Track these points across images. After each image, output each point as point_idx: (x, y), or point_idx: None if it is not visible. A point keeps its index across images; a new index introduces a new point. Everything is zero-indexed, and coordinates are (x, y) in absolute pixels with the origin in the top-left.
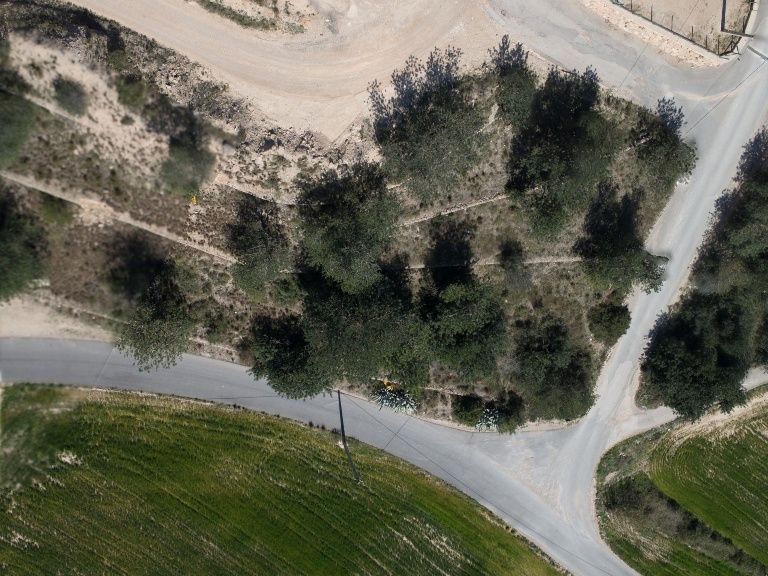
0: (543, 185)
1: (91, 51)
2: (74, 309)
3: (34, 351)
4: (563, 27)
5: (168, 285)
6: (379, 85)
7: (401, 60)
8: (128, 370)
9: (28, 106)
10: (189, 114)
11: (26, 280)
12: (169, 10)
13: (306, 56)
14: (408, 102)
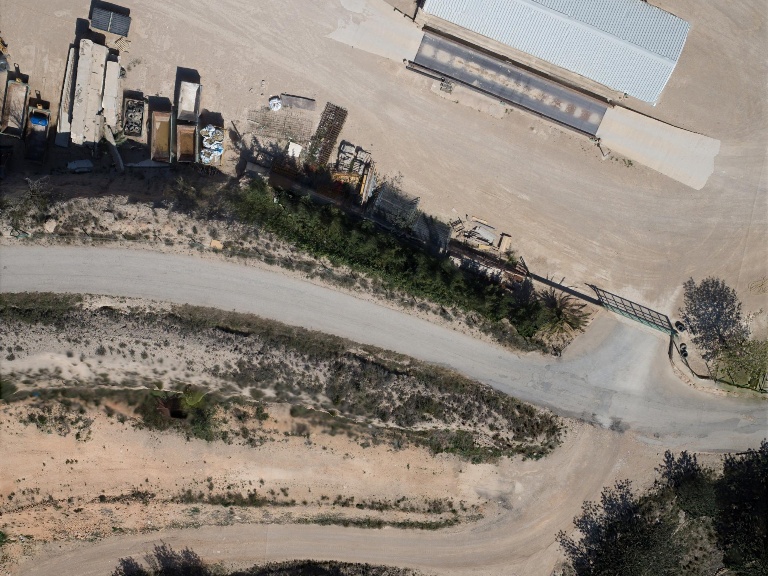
0: (758, 561)
1: None
2: None
3: None
4: (721, 421)
5: None
6: (565, 533)
7: (577, 508)
8: None
9: None
10: None
11: None
12: (370, 538)
13: (493, 533)
14: (597, 538)
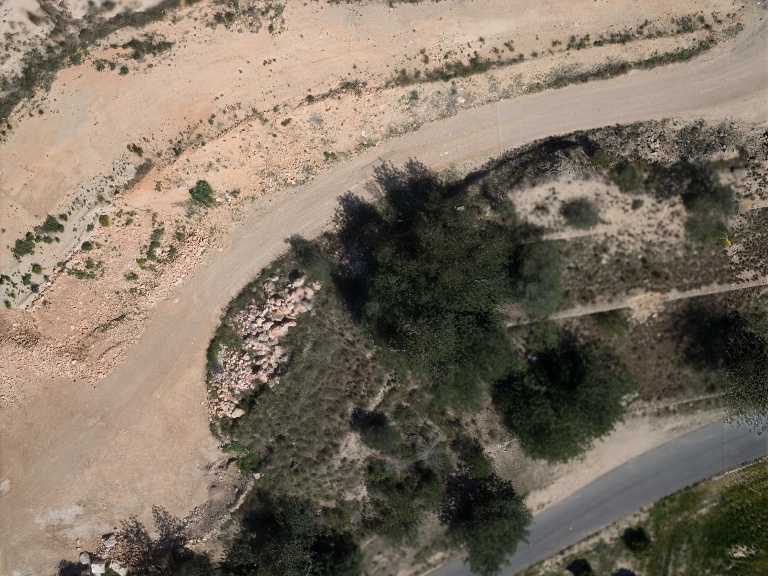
0: None
1: (577, 165)
2: (670, 406)
3: (655, 464)
4: None
5: (743, 337)
6: None
7: None
8: (748, 439)
9: (548, 246)
10: (685, 165)
11: (617, 401)
12: (616, 91)
13: (757, 48)
14: None
